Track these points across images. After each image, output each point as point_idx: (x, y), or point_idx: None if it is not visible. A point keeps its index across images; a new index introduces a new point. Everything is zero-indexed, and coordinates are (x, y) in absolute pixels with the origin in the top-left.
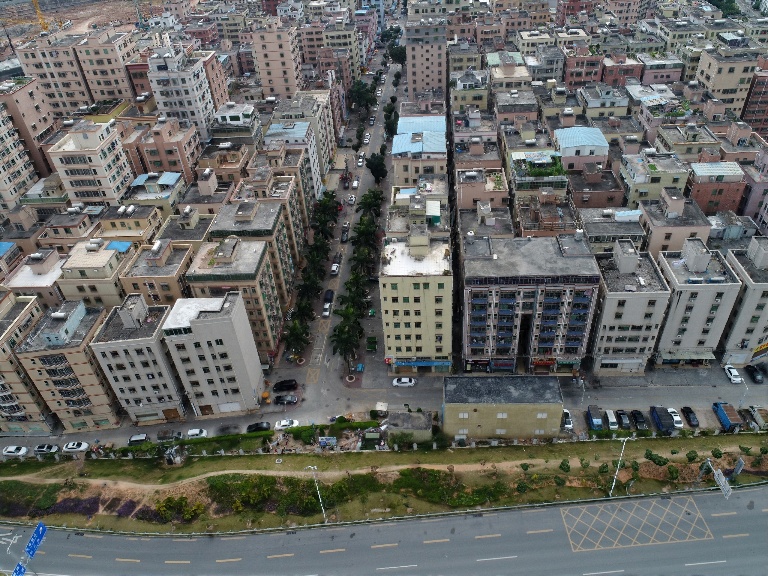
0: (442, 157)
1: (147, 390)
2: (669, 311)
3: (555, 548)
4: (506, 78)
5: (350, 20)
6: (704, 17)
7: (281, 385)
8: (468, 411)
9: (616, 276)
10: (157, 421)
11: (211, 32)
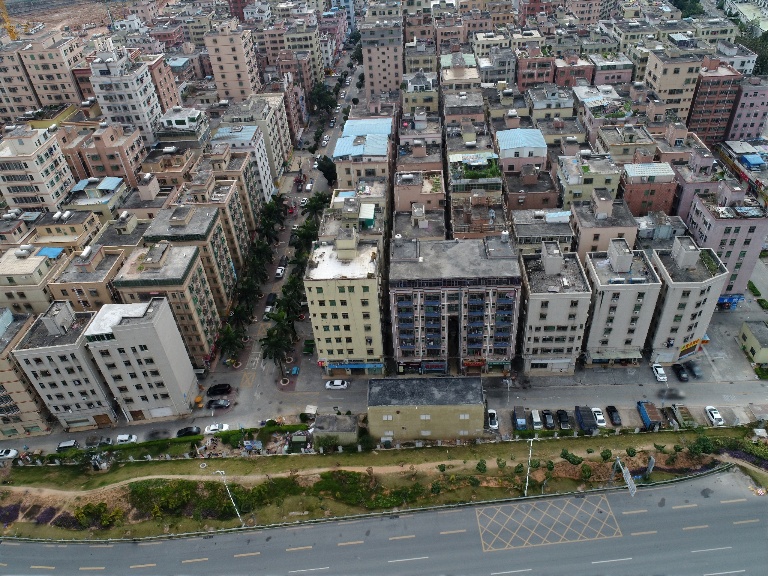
0: (383, 160)
1: (75, 396)
2: (594, 311)
3: (466, 548)
4: (455, 80)
5: (318, 22)
6: (659, 18)
7: (214, 389)
8: (391, 413)
9: (541, 277)
10: (88, 427)
11: (176, 35)
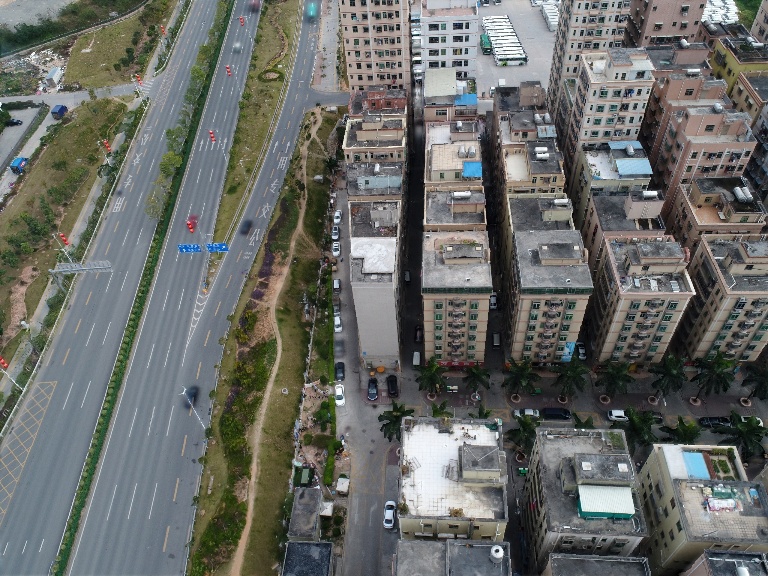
0: None
1: None
2: None
3: None
4: None
5: None
6: None
7: (389, 380)
8: None
9: None
10: None
11: None
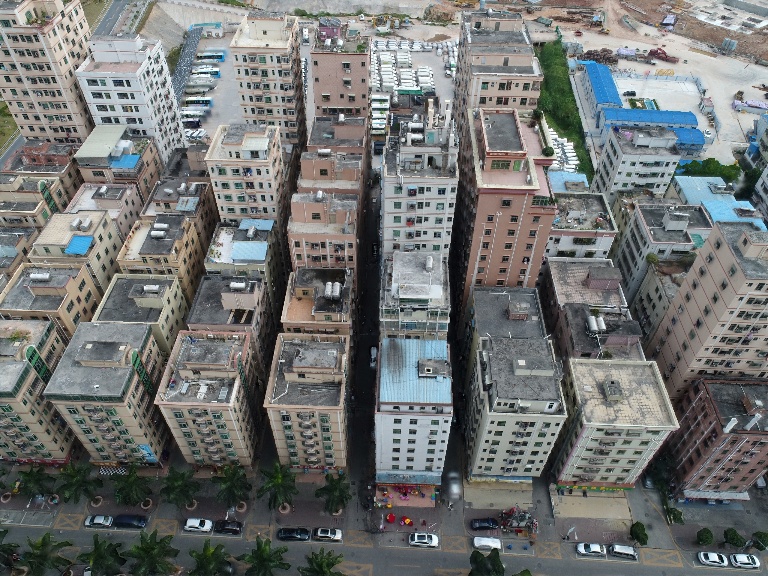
0: None
1: None
2: None
3: None
4: None
5: None
6: None
7: None
8: None
9: None
10: None
11: None
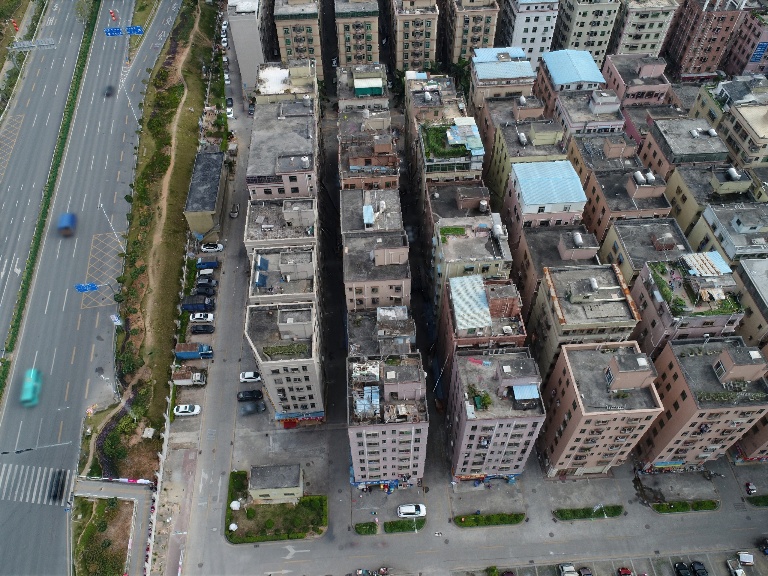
0: None
1: None
2: None
3: (98, 227)
4: (740, 115)
5: None
6: None
7: None
8: None
9: (282, 213)
10: None
11: None
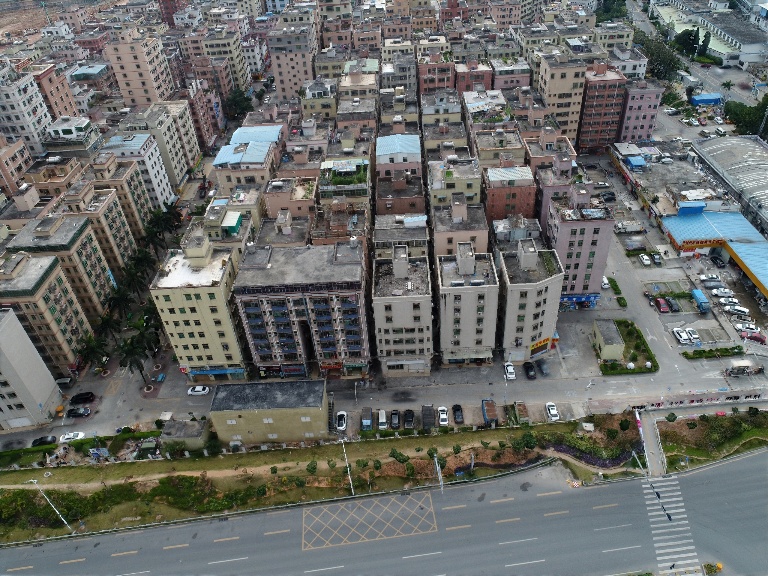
0: (261, 167)
1: None
2: (440, 313)
3: (286, 548)
4: (350, 86)
5: (252, 27)
6: (565, 22)
7: (76, 398)
8: (234, 418)
9: (389, 281)
10: None
11: (102, 41)
